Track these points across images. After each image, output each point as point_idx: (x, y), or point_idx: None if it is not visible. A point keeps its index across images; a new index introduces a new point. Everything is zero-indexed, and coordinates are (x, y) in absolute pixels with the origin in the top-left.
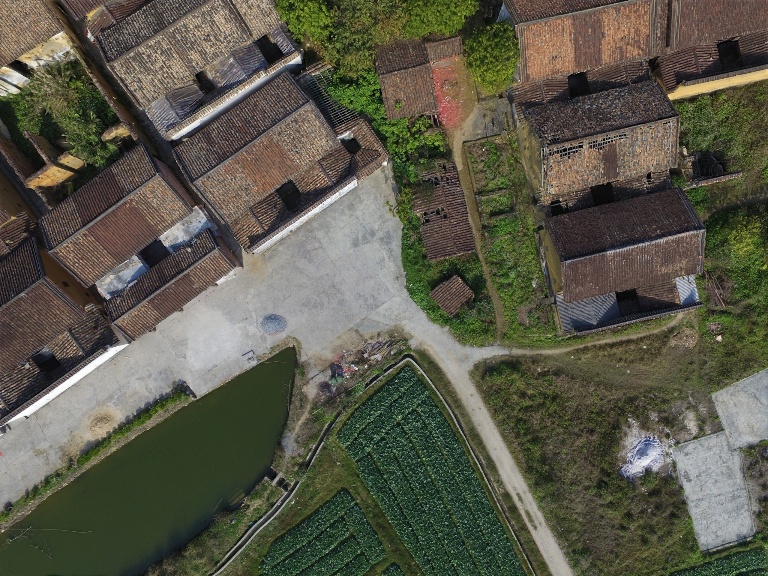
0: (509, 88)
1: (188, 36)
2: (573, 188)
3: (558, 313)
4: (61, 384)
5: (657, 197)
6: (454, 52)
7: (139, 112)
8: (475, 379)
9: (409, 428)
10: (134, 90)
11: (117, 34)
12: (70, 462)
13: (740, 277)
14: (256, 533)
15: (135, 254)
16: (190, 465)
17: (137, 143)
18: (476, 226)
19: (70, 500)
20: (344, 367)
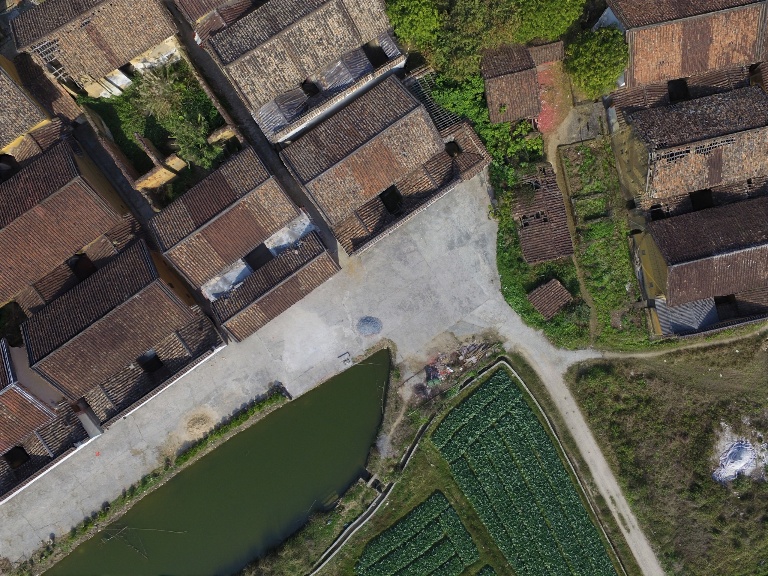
0: (610, 93)
1: (302, 39)
2: (676, 193)
3: (652, 317)
4: (168, 385)
5: (760, 202)
6: (555, 56)
7: (238, 114)
8: (569, 382)
9: (503, 430)
10: (247, 93)
11: (230, 37)
12: (167, 462)
13: None
14: (351, 534)
15: (244, 256)
16: (285, 466)
17: (243, 145)
18: (570, 230)
19: (165, 500)
20: (439, 369)
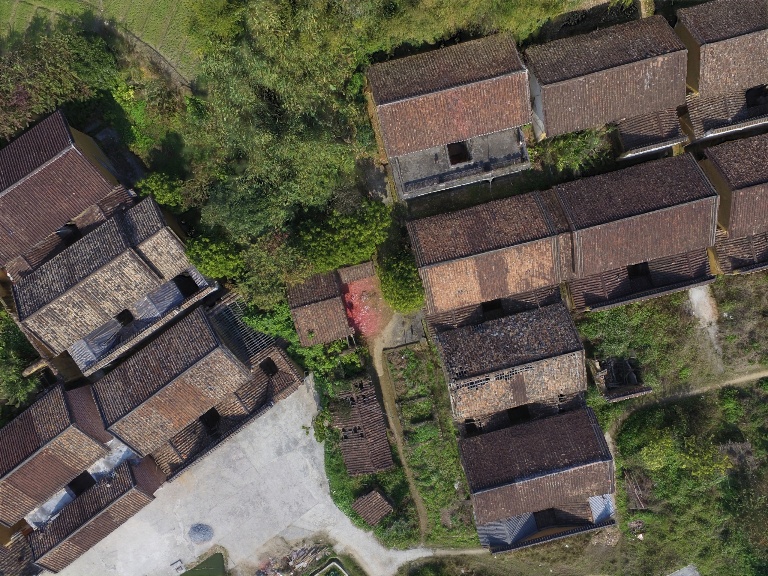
0: (422, 308)
1: (99, 288)
2: (484, 412)
3: None
4: None
5: (567, 419)
6: (367, 274)
7: None
8: None
9: None
10: (48, 340)
11: (31, 285)
12: None
13: (659, 478)
14: None
15: None
16: None
17: (57, 378)
18: (398, 430)
19: None
20: (270, 575)
